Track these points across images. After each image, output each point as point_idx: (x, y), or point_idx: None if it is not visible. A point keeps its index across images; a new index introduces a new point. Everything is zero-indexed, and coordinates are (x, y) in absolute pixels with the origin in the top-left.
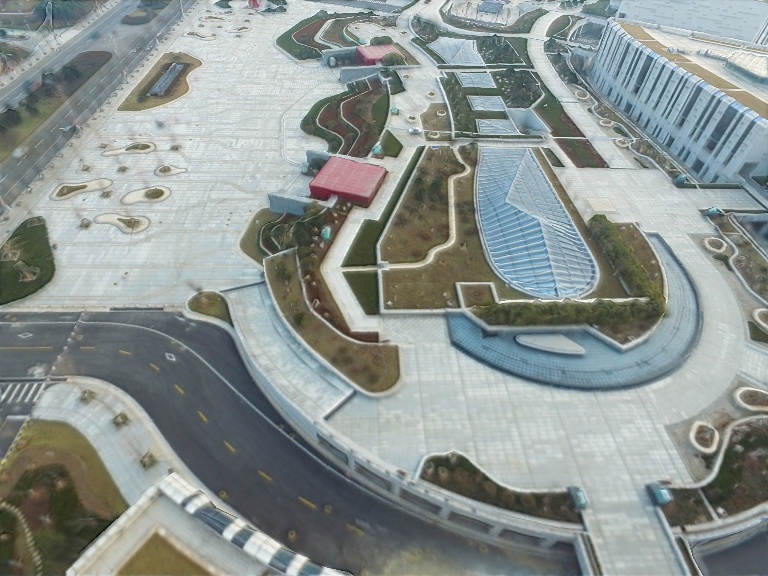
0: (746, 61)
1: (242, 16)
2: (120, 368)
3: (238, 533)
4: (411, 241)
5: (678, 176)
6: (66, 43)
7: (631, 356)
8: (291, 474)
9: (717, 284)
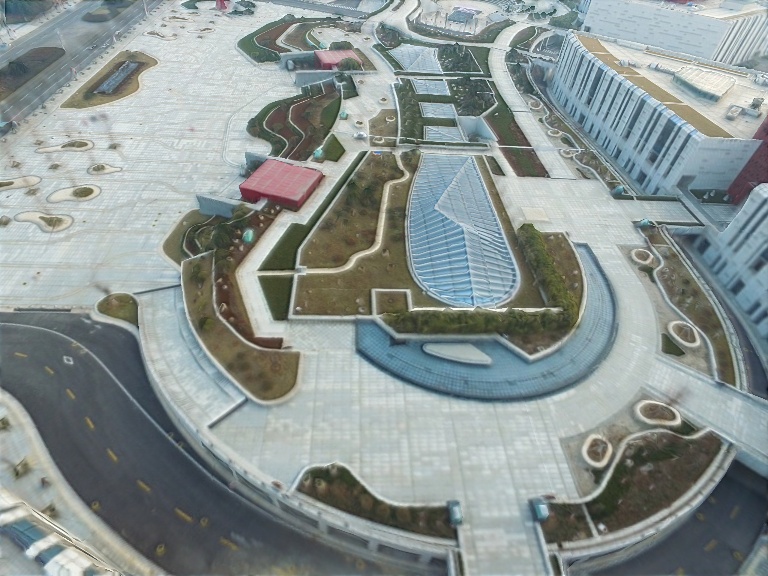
0: (692, 76)
1: (207, 17)
2: (12, 371)
3: (46, 549)
4: (334, 246)
5: (616, 187)
6: (20, 38)
7: (538, 367)
8: (172, 484)
9: (637, 296)
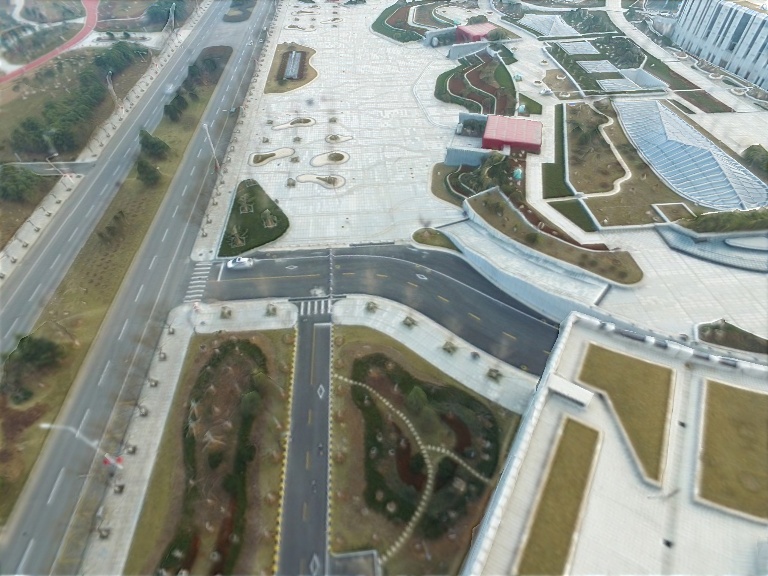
0: None
1: (328, 9)
2: (386, 286)
3: (656, 339)
4: (594, 176)
5: None
6: (185, 41)
7: None
8: None
9: None
